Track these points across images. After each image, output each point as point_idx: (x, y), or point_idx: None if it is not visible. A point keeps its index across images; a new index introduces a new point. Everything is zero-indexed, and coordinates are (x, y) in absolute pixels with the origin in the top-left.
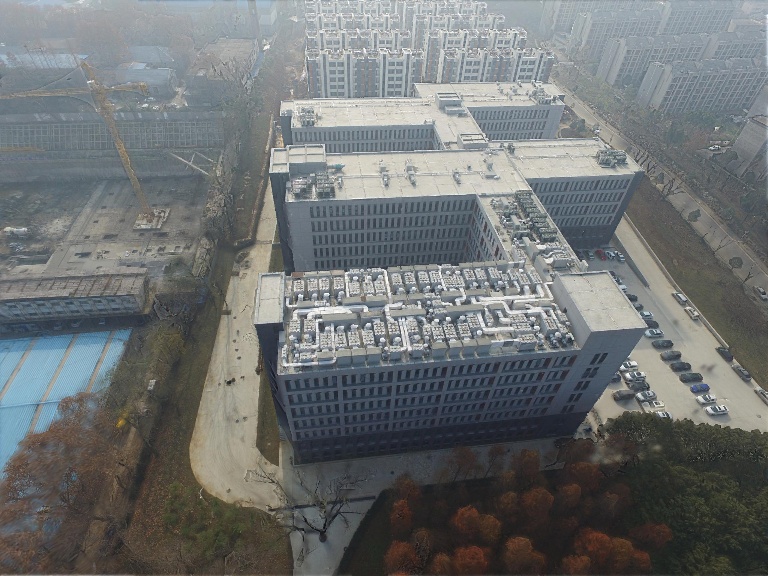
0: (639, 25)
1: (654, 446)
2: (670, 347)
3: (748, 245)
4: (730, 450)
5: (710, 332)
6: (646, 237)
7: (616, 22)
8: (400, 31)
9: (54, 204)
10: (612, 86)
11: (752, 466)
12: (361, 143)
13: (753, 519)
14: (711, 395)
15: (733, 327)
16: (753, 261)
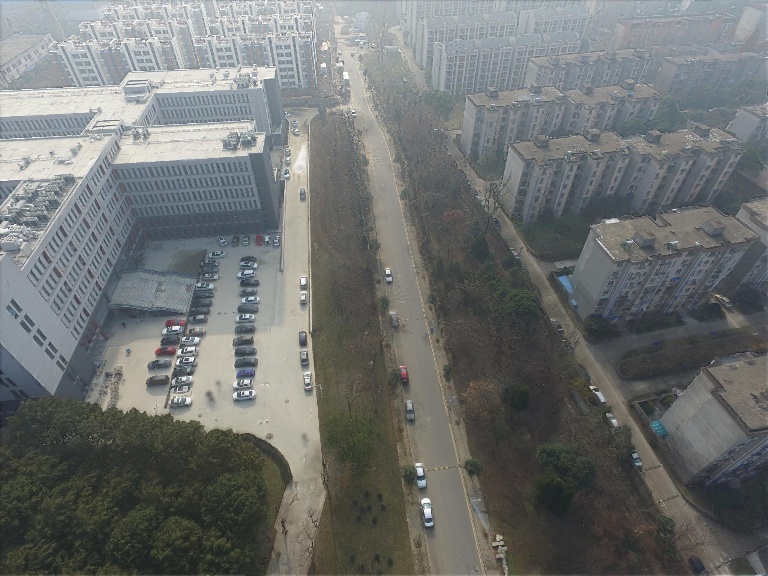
0: (470, 5)
1: (7, 430)
2: (251, 332)
3: (415, 227)
4: (75, 433)
5: (308, 316)
6: (313, 221)
7: (443, 2)
8: (179, 20)
9: None
10: (422, 69)
11: (92, 450)
12: (32, 133)
13: (26, 503)
14: (246, 380)
15: (329, 311)
16: (408, 243)
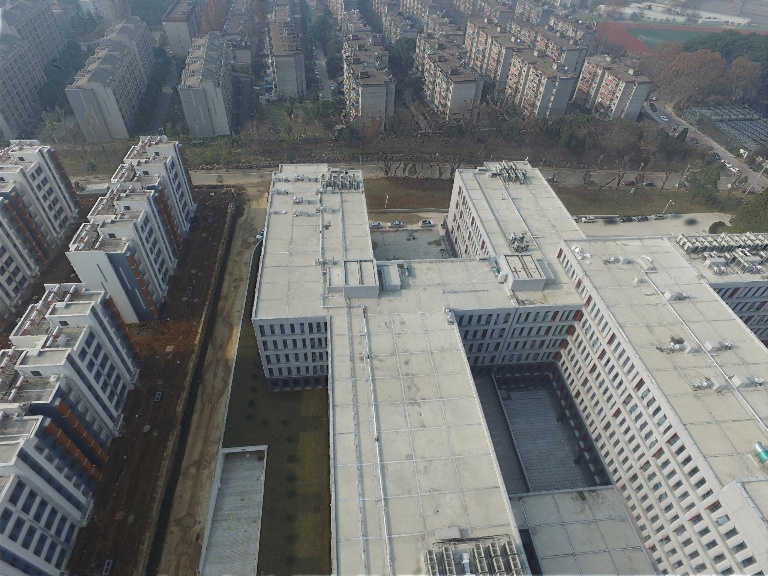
0: (20, 61)
1: None
2: None
3: None
4: None
5: (603, 219)
6: None
7: (1, 69)
8: None
9: None
10: None
11: None
12: None
13: None
14: None
15: (598, 205)
16: None
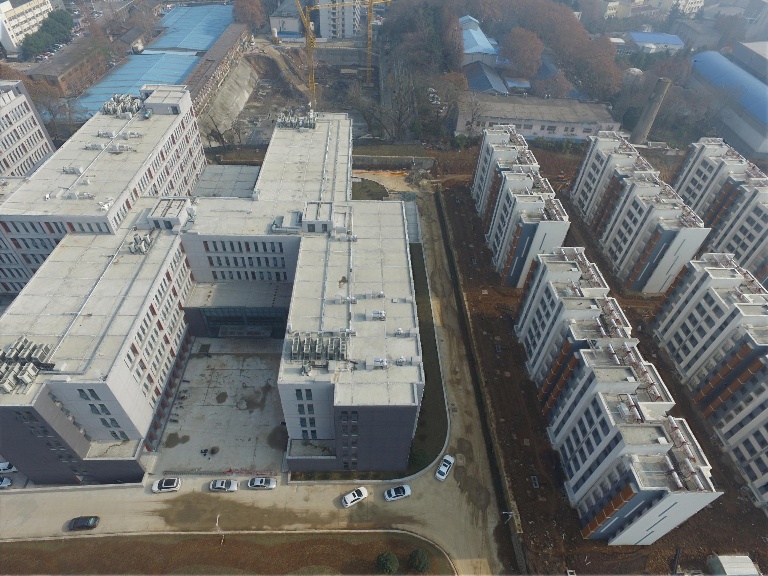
0: None
1: None
2: None
3: None
4: None
5: None
6: None
7: None
8: None
9: (350, 113)
10: None
11: None
12: None
13: None
14: None
15: None
16: None
